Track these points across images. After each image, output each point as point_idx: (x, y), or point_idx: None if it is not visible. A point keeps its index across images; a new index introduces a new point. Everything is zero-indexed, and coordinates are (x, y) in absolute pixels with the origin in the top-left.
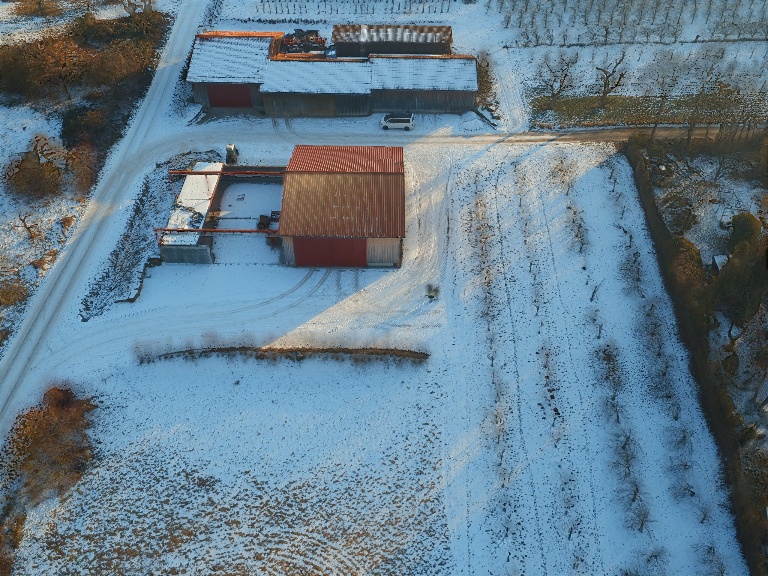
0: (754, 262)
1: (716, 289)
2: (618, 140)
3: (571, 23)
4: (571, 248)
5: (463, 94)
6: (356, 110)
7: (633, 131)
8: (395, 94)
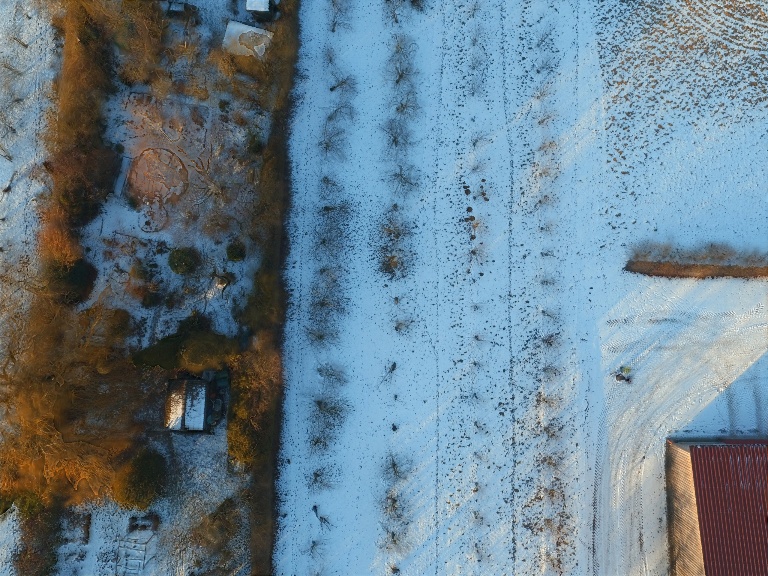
0: (135, 439)
1: (231, 342)
2: None
3: None
4: None
5: None
6: None
7: None
8: None
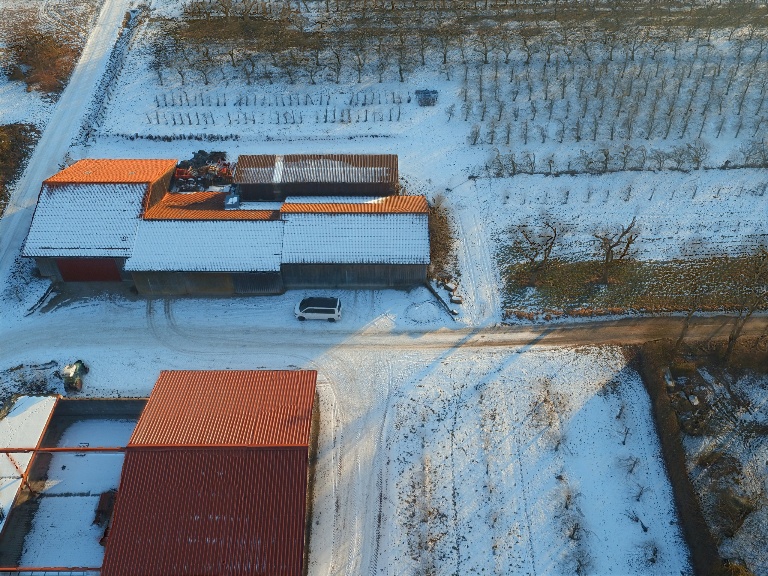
0: None
1: None
2: (627, 343)
3: (559, 139)
4: (563, 571)
5: (410, 266)
6: (263, 287)
7: (648, 324)
8: (316, 267)
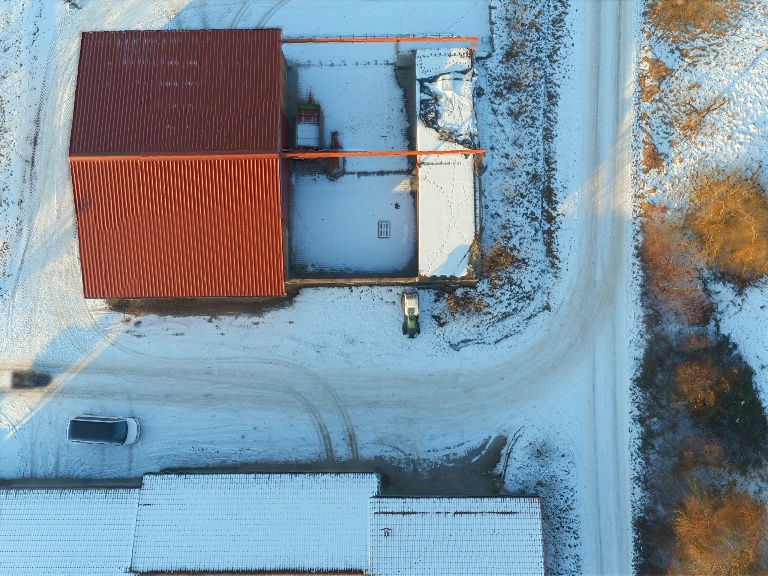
0: None
1: None
2: None
3: None
4: None
5: None
6: None
7: None
8: None
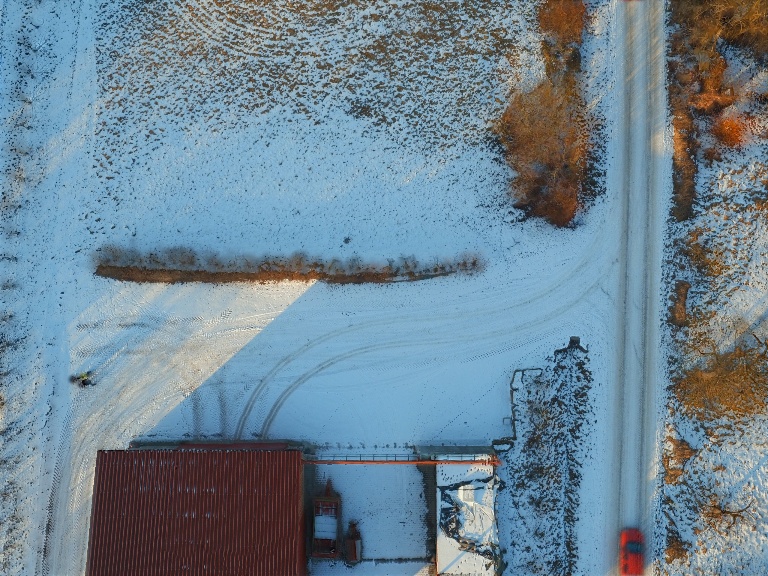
0: None
1: None
2: None
3: None
4: None
5: None
6: None
7: None
8: None
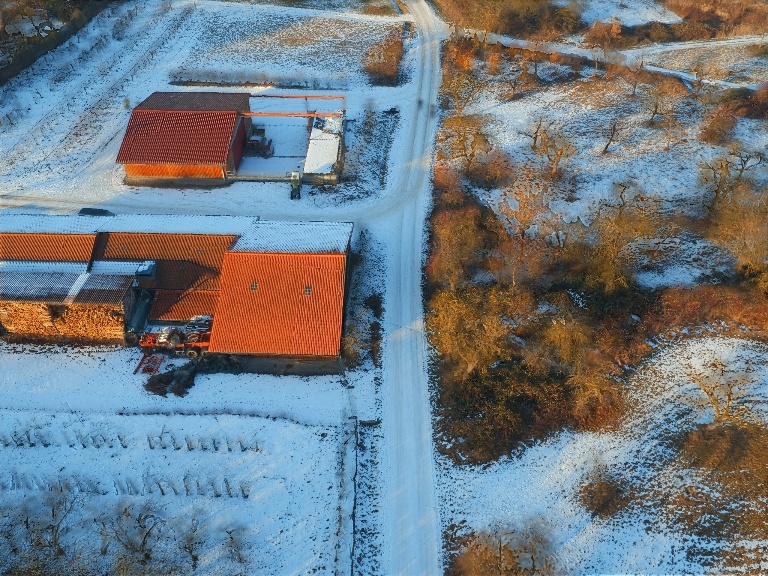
0: None
1: None
2: None
3: None
4: None
5: None
6: None
7: None
8: None
